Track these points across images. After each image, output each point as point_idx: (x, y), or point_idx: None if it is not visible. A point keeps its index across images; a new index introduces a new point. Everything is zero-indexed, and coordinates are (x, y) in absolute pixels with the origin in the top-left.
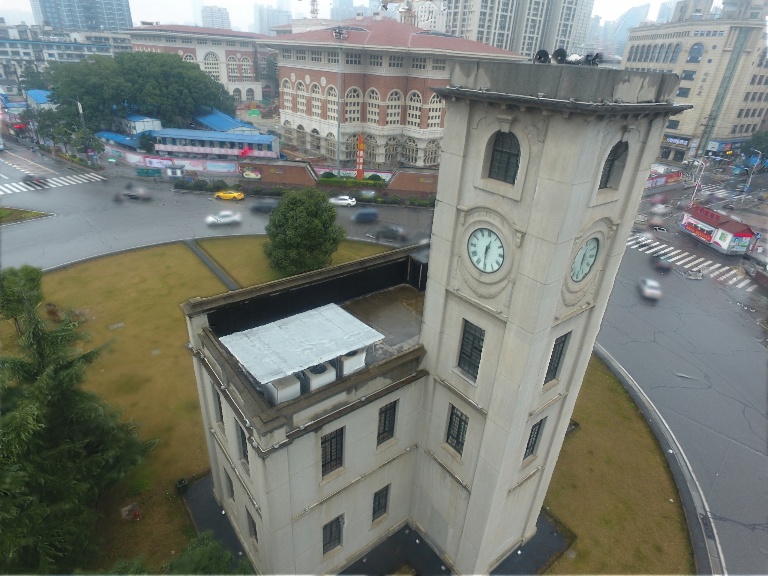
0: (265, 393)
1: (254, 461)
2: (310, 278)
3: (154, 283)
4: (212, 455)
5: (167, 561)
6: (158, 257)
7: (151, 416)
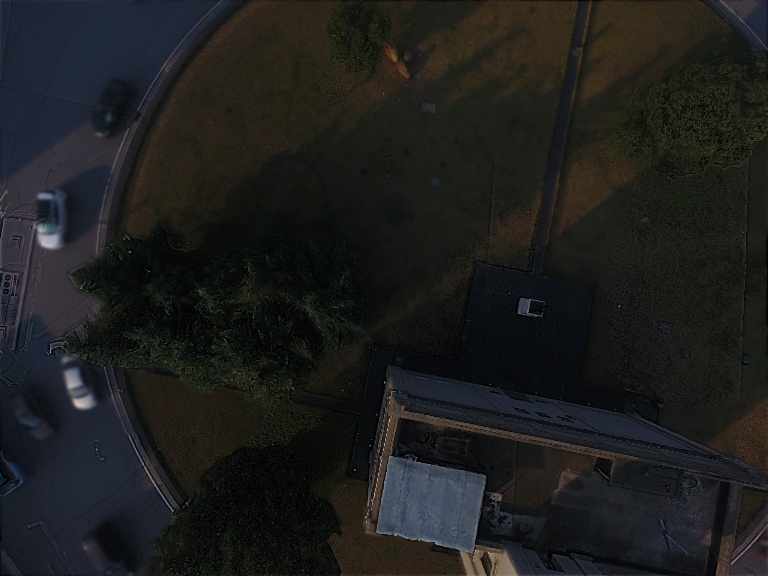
0: None
1: None
2: (498, 434)
3: (498, 43)
4: None
5: (345, 387)
6: None
7: (392, 264)
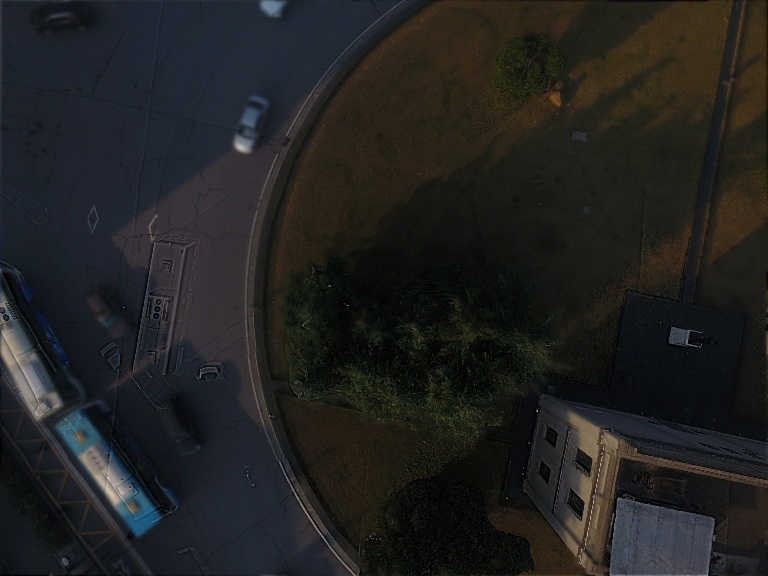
0: (608, 549)
1: (573, 526)
2: (729, 477)
3: (649, 72)
4: (557, 414)
5: None
6: (687, 0)
7: (544, 292)
